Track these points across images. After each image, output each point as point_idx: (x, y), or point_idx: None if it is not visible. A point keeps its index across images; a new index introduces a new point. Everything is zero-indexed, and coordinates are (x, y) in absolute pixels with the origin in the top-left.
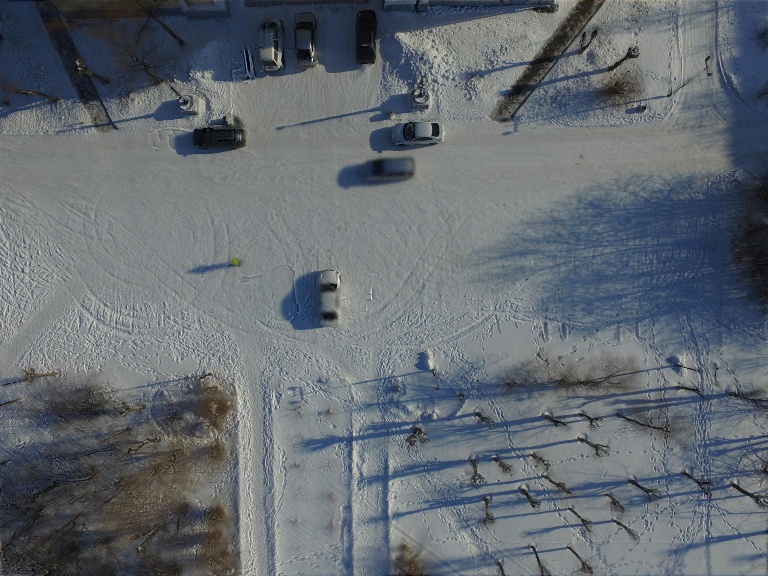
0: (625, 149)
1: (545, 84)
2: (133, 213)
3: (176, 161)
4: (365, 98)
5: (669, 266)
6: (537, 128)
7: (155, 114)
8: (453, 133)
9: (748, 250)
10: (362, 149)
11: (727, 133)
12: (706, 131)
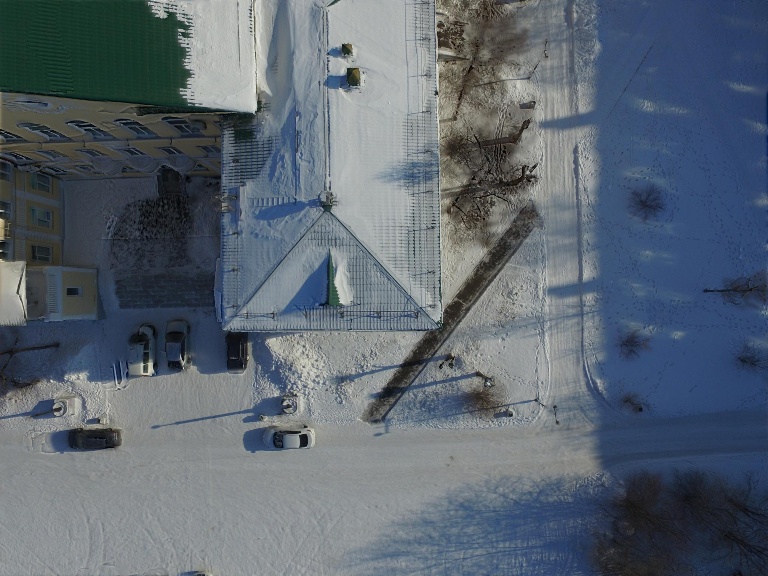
0: (495, 451)
1: (414, 388)
2: (10, 510)
3: (53, 458)
4: (238, 400)
5: (538, 569)
6: (407, 430)
7: (32, 413)
8: (325, 434)
9: (615, 556)
10: (236, 449)
11: (594, 436)
12: (574, 434)
